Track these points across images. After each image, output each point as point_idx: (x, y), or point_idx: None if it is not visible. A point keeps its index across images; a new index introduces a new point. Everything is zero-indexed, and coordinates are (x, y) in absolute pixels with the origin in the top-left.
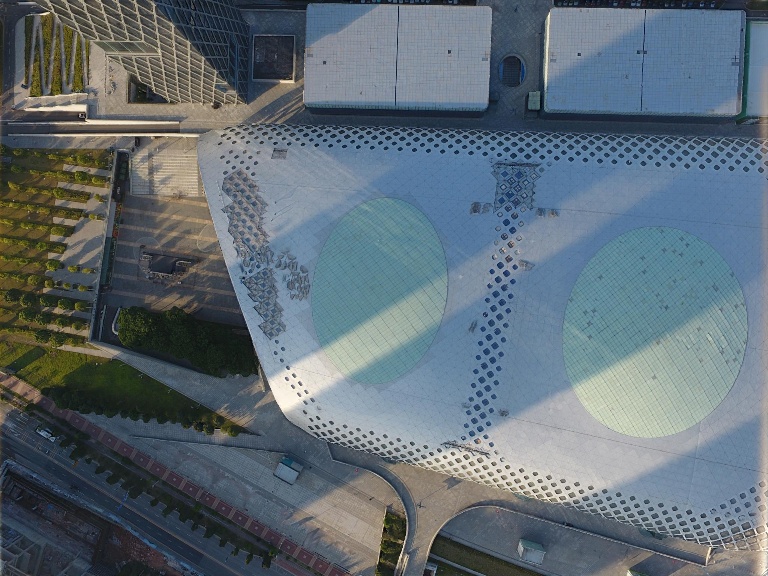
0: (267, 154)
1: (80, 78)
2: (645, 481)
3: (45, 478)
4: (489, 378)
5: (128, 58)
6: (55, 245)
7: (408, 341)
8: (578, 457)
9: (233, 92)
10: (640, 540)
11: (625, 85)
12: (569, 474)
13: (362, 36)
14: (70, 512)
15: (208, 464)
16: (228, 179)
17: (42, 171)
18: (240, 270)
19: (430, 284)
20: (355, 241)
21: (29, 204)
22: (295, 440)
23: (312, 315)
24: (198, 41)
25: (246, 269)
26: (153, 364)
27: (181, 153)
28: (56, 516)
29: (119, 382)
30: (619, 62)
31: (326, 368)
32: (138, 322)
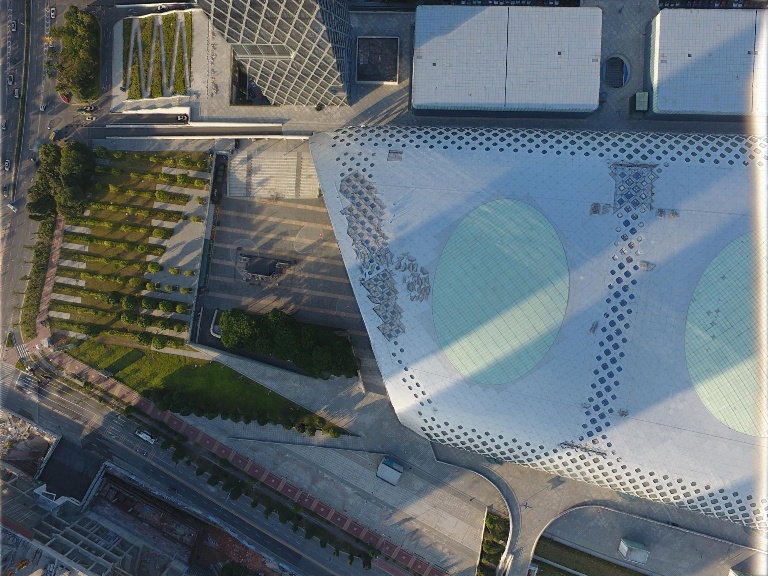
0: (383, 156)
1: (182, 81)
2: (764, 480)
3: (143, 480)
4: (609, 378)
5: (257, 61)
6: (154, 247)
7: (529, 342)
8: (697, 457)
9: (343, 94)
10: (745, 539)
11: (736, 86)
12: (686, 474)
13: (472, 38)
14: (167, 514)
15: (307, 465)
16: (345, 181)
17: (141, 173)
18: (360, 272)
19: (552, 285)
20: (476, 242)
21: (127, 206)
22: (395, 441)
23: (432, 316)
24: (334, 44)
25: (366, 271)
26: (252, 366)
27: (281, 155)
28: (152, 518)
29: (218, 384)
30: (730, 63)
31: (445, 369)
32: (242, 324)
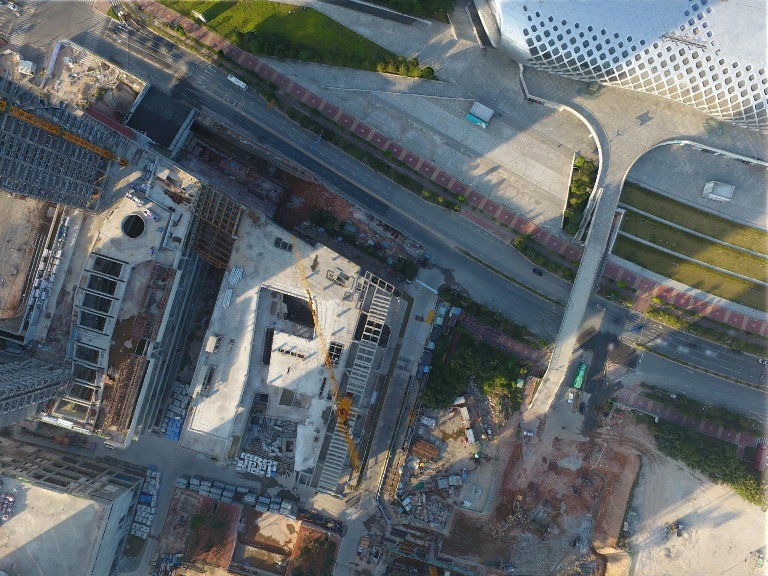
0: None
1: None
2: None
3: (232, 128)
4: None
5: None
6: None
7: None
8: None
9: None
10: None
11: None
12: None
13: None
14: (253, 169)
15: (397, 115)
16: None
17: None
18: None
19: None
20: None
21: None
22: (485, 88)
23: None
24: None
25: None
26: (346, 12)
27: None
28: (238, 173)
29: (311, 30)
30: None
31: None
32: None
